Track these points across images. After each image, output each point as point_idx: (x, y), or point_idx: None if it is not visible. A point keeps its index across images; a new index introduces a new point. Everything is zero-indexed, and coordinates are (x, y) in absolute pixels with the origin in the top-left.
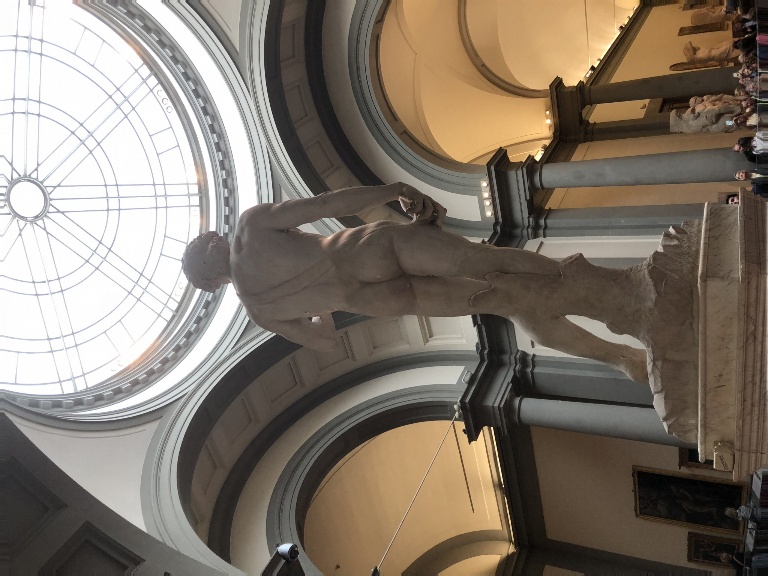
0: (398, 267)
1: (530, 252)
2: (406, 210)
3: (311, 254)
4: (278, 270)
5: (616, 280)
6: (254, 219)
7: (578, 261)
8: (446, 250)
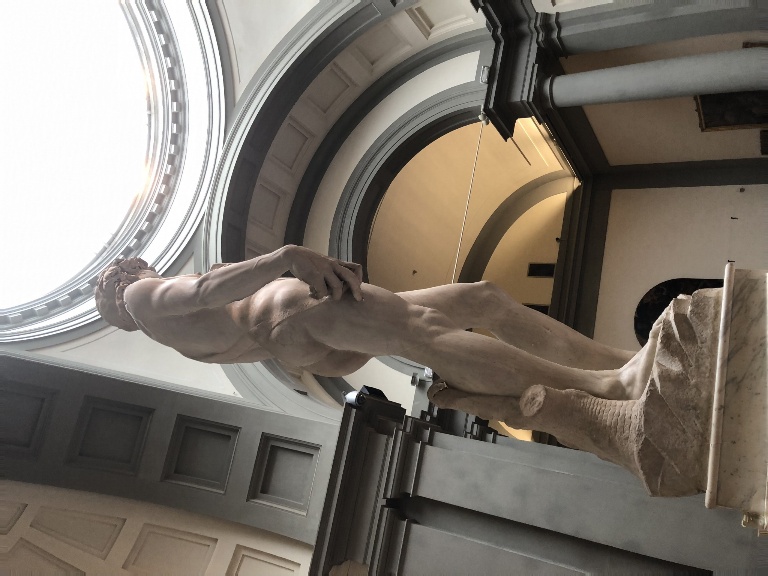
0: (330, 348)
1: (481, 359)
2: (308, 294)
3: (226, 332)
4: (201, 348)
5: (597, 444)
6: (141, 312)
7: (543, 413)
8: (377, 342)
